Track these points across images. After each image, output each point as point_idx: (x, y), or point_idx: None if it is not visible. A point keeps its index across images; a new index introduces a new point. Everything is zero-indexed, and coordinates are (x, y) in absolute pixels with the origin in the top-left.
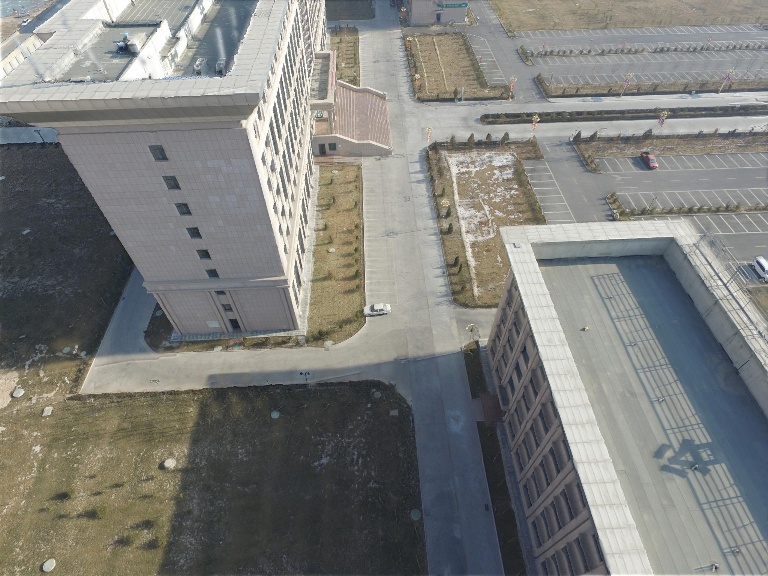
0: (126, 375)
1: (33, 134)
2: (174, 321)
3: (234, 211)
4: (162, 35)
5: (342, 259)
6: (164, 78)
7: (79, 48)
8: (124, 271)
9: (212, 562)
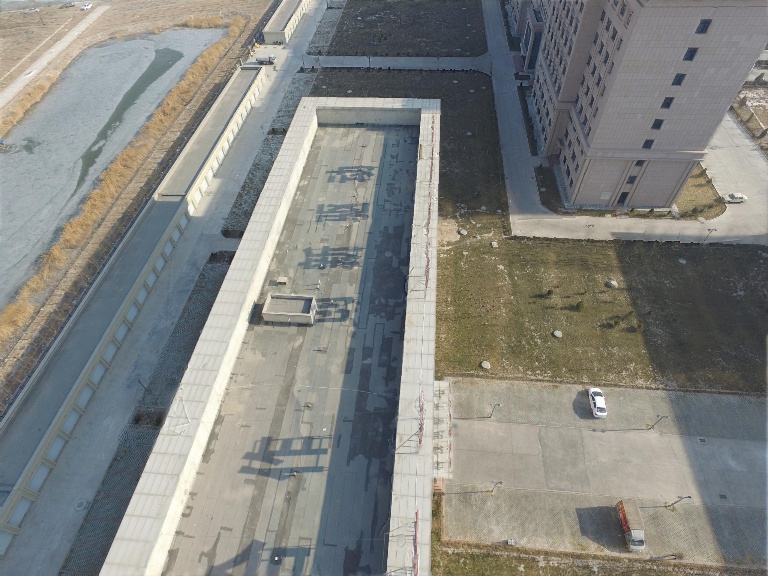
0: (543, 227)
1: (353, 61)
2: (579, 189)
3: (716, 83)
4: None
5: None
6: None
7: None
8: (496, 160)
9: (684, 344)
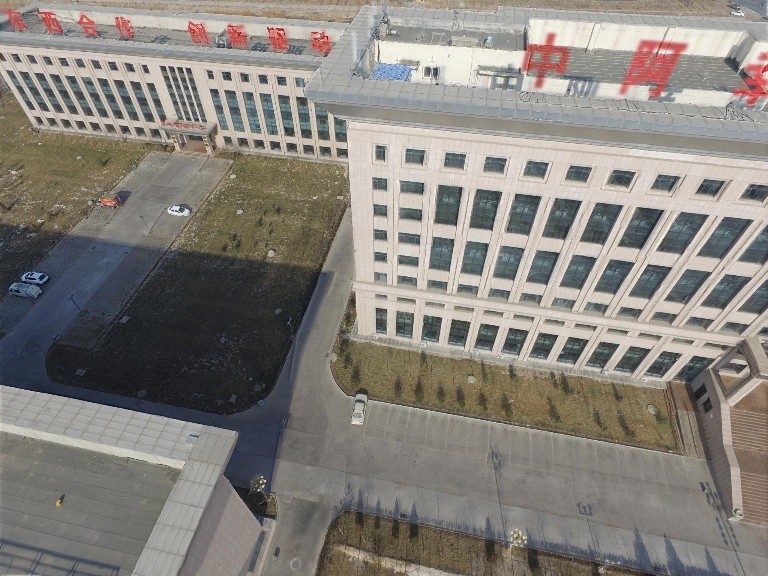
0: None
1: None
2: None
3: None
4: (504, 58)
5: (454, 389)
6: (405, 66)
7: (465, 26)
8: None
9: (195, 275)
